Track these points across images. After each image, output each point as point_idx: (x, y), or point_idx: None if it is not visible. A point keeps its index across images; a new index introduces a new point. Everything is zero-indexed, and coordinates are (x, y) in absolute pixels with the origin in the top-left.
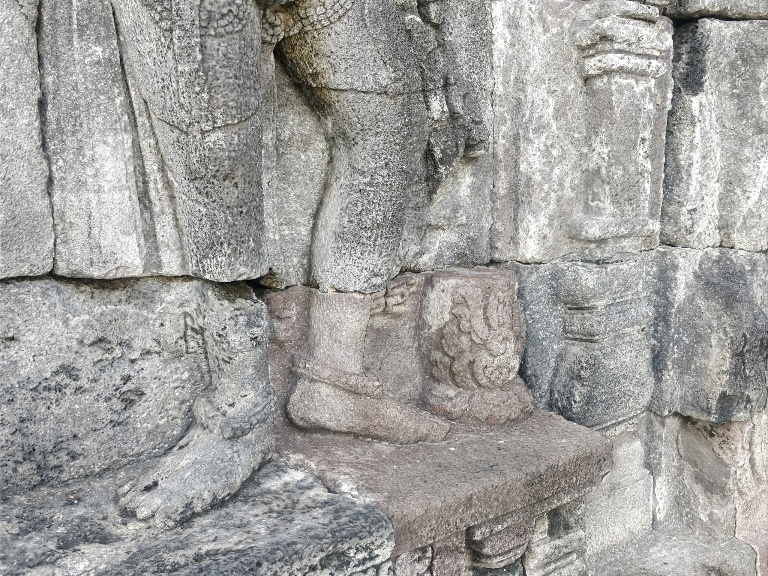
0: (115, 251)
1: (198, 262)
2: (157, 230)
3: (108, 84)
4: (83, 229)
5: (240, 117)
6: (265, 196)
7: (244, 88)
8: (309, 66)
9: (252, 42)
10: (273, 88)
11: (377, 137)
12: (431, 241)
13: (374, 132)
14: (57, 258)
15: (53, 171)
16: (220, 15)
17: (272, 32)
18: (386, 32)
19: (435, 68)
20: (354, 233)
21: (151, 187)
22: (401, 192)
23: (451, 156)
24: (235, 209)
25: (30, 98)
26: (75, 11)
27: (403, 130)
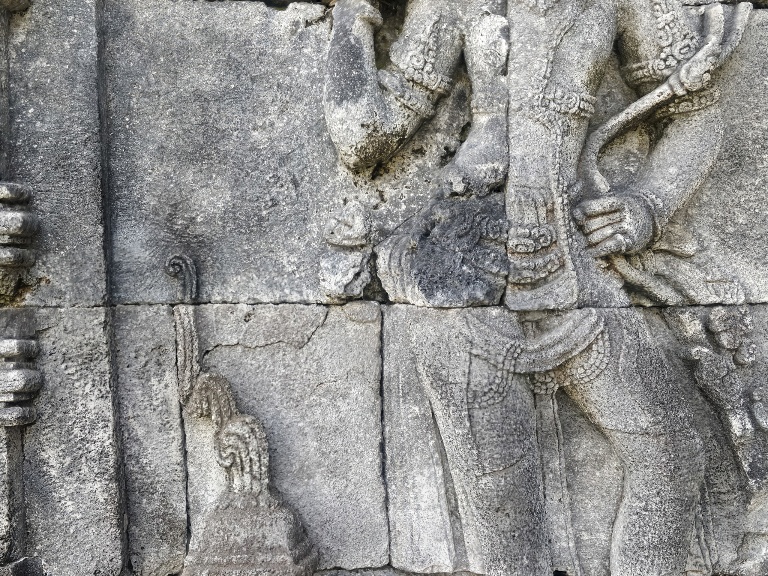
0: (430, 554)
1: (488, 569)
2: (464, 537)
3: (423, 432)
4: (407, 536)
5: (505, 465)
6: (556, 511)
7: (507, 443)
8: (585, 408)
9: (515, 406)
10: (557, 425)
11: (646, 469)
12: (755, 547)
13: (643, 465)
14: (391, 555)
15: (389, 493)
16: (483, 393)
17: (545, 387)
18: (642, 384)
19: (731, 390)
20: (633, 551)
21: (459, 504)
22: (677, 517)
23: (763, 469)
24: (508, 533)
25: (374, 443)
26: (401, 384)
27: (670, 464)
